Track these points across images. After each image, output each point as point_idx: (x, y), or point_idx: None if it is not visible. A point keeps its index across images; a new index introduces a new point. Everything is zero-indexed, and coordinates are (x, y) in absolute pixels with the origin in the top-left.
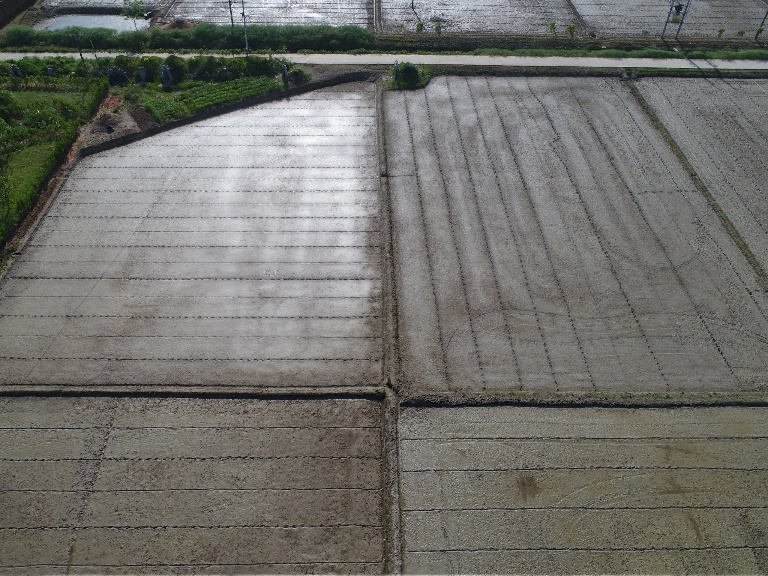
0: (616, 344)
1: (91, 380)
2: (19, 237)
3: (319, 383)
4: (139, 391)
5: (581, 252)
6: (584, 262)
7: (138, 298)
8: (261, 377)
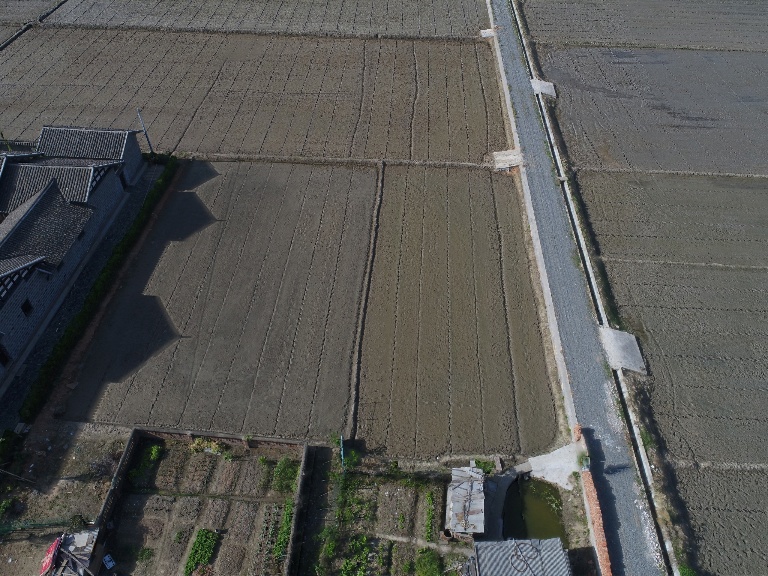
0: None
1: None
2: None
3: (6, 39)
4: None
5: None
6: None
7: None
8: None
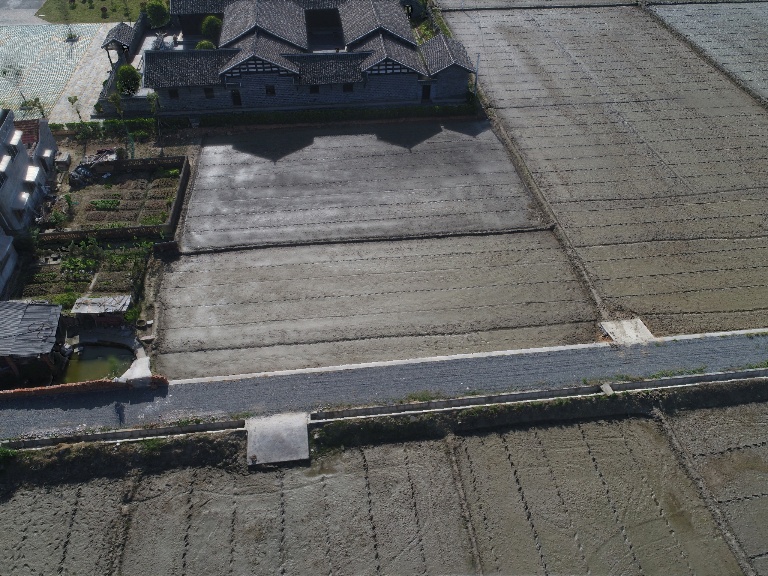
0: None
1: (506, 6)
2: None
3: (606, 3)
4: (532, 6)
5: None
6: None
7: None
8: (579, 3)
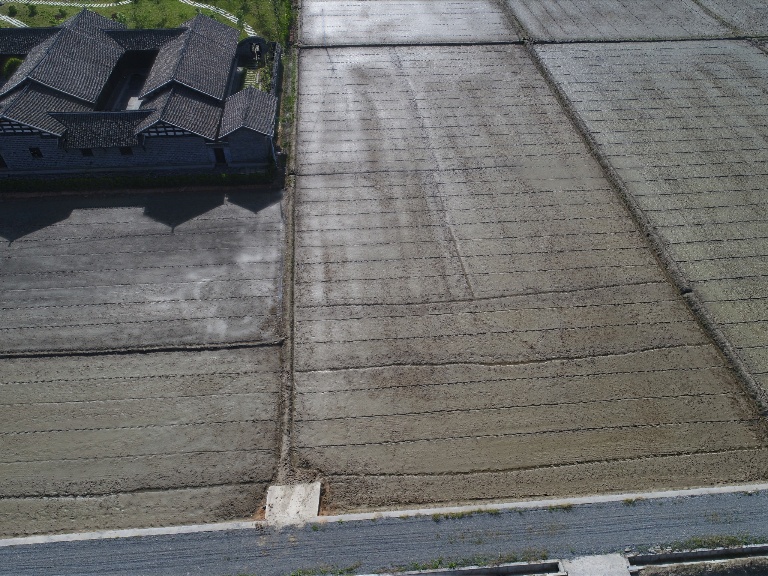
0: (631, 27)
1: (376, 42)
2: (295, 3)
3: None
4: (404, 44)
5: (606, 1)
6: (608, 4)
7: (379, 20)
8: (460, 40)
